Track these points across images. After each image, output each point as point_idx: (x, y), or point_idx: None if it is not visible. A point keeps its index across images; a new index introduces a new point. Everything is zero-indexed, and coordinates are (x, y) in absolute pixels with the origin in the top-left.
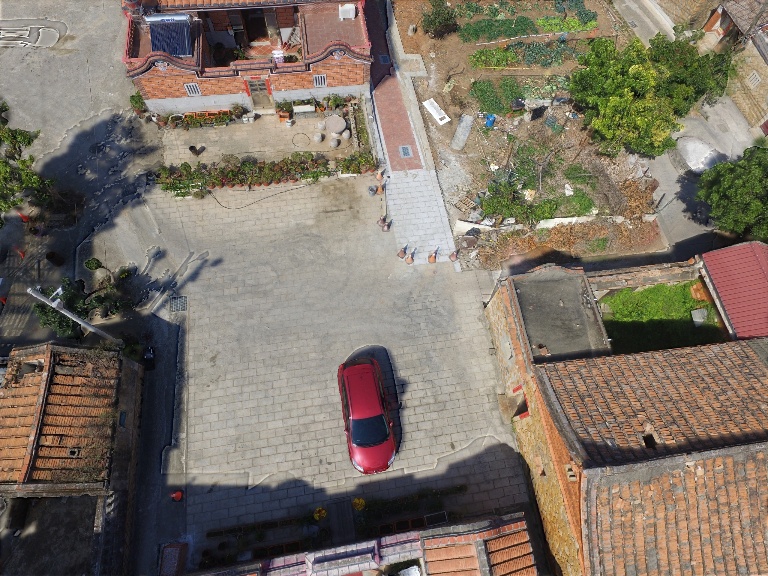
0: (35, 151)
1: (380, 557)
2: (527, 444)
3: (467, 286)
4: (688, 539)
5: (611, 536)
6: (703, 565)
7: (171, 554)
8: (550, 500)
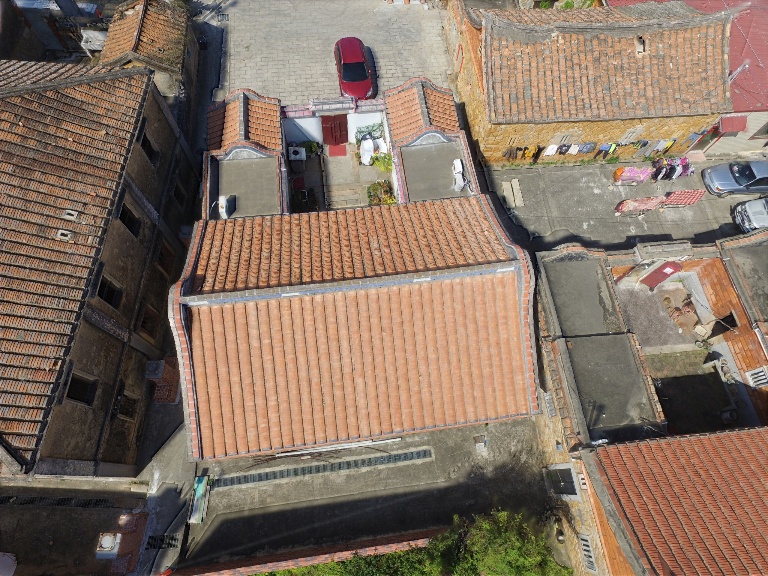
0: None
1: (356, 106)
2: (463, 86)
3: (432, 17)
4: (552, 83)
5: (501, 74)
6: (561, 100)
7: None
8: (473, 100)
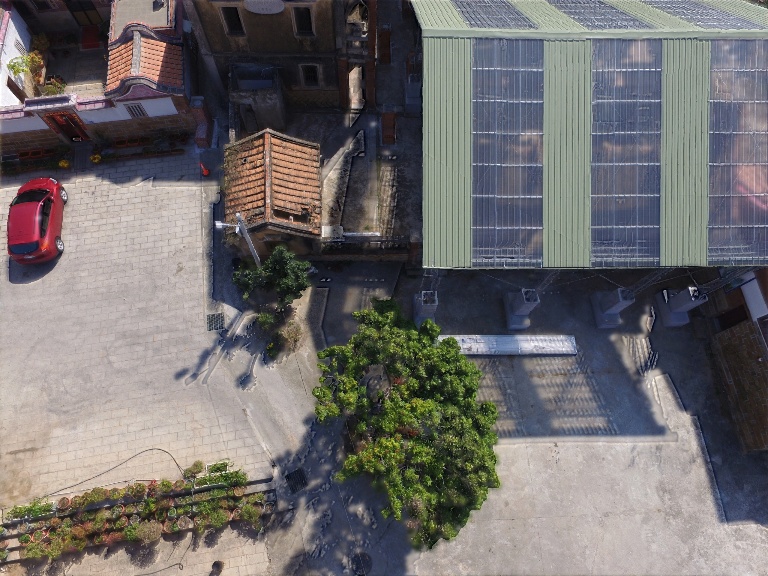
0: (445, 553)
1: None
2: None
3: None
4: None
5: None
6: None
7: (200, 135)
8: None
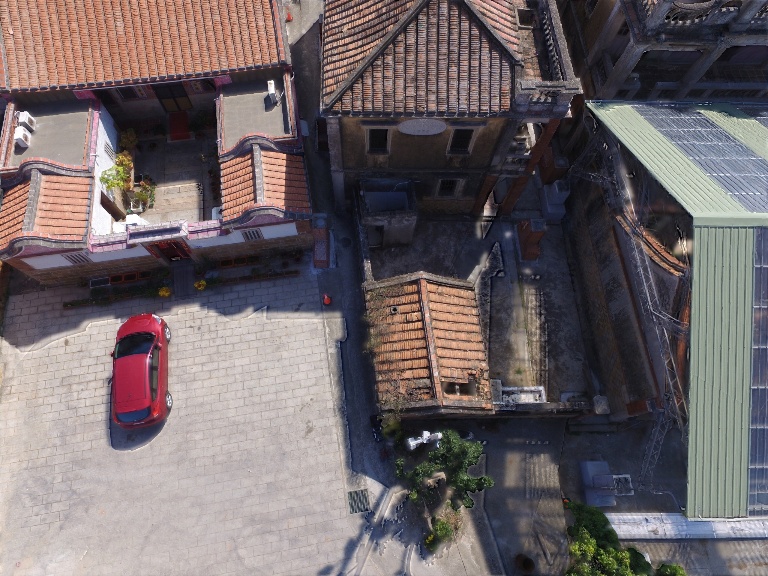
0: None
1: None
2: None
3: None
4: None
5: None
6: None
7: (320, 256)
8: None
